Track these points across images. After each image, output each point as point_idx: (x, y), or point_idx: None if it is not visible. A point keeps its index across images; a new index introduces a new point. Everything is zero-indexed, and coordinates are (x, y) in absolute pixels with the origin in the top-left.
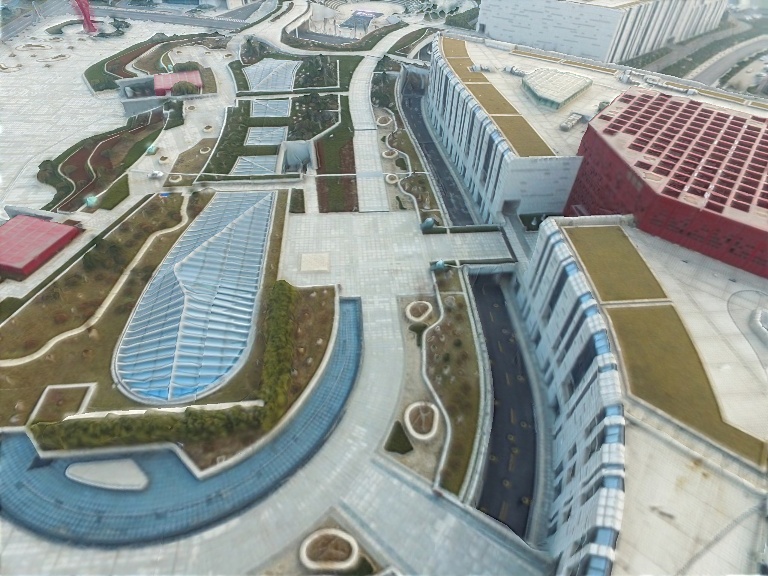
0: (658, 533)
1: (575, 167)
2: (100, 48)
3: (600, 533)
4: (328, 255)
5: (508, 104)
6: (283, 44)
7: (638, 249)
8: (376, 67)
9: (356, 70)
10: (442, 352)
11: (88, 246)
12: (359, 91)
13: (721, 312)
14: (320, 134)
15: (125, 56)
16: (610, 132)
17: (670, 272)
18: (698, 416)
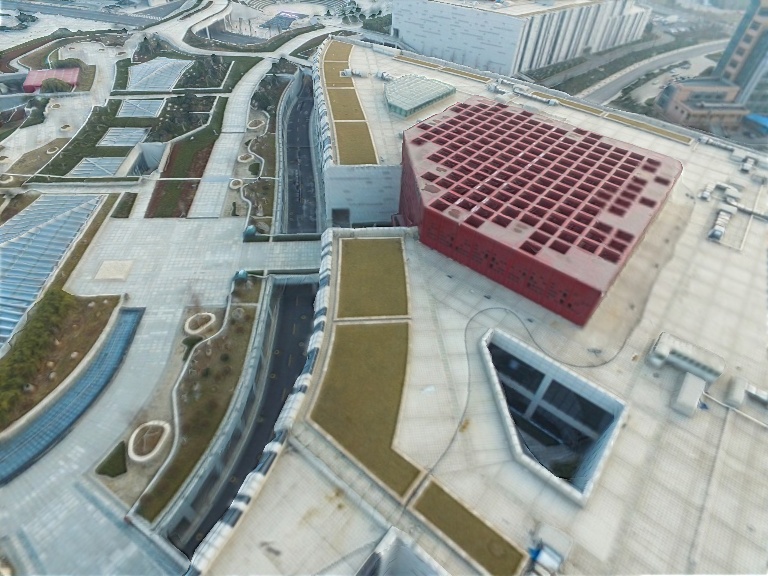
0: (252, 572)
1: (397, 176)
2: None
3: (187, 573)
4: (131, 263)
5: (359, 110)
6: (184, 43)
7: (406, 263)
8: (270, 69)
9: (249, 71)
10: (204, 367)
11: None
12: (242, 93)
13: (457, 330)
14: (181, 136)
15: (16, 51)
16: (419, 141)
17: (428, 287)
18: (367, 442)
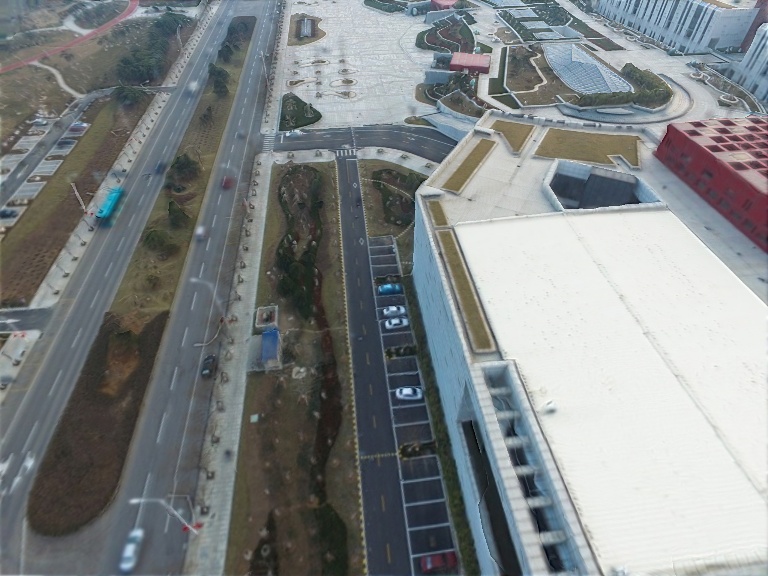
0: None
1: (754, 15)
2: None
3: None
4: None
5: None
6: None
7: None
8: None
9: None
10: None
11: (502, 63)
12: (567, 5)
13: None
14: (568, 23)
15: None
16: None
17: None
18: None
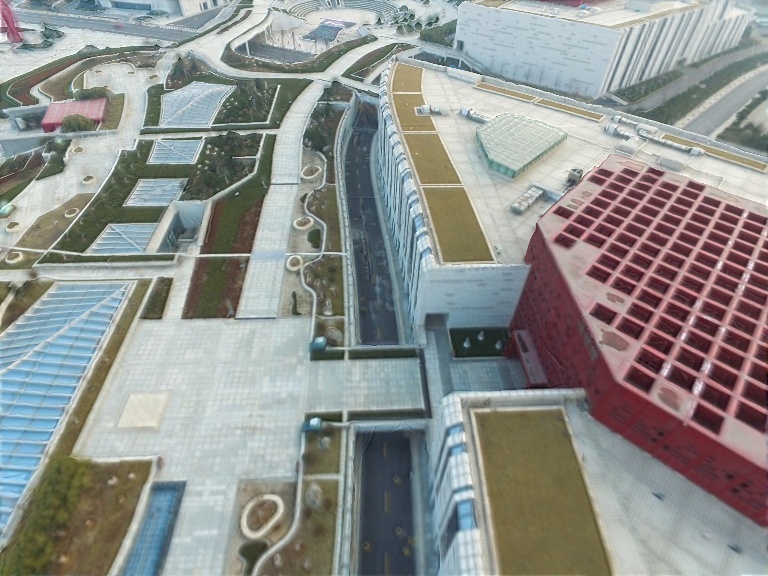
0: None
1: (520, 277)
2: (18, 63)
3: None
4: (166, 397)
5: (450, 167)
6: (222, 63)
7: (583, 466)
8: (322, 95)
9: (297, 99)
10: None
11: None
12: (292, 128)
13: None
14: (223, 191)
15: (38, 75)
16: (565, 241)
17: (630, 521)
18: None
